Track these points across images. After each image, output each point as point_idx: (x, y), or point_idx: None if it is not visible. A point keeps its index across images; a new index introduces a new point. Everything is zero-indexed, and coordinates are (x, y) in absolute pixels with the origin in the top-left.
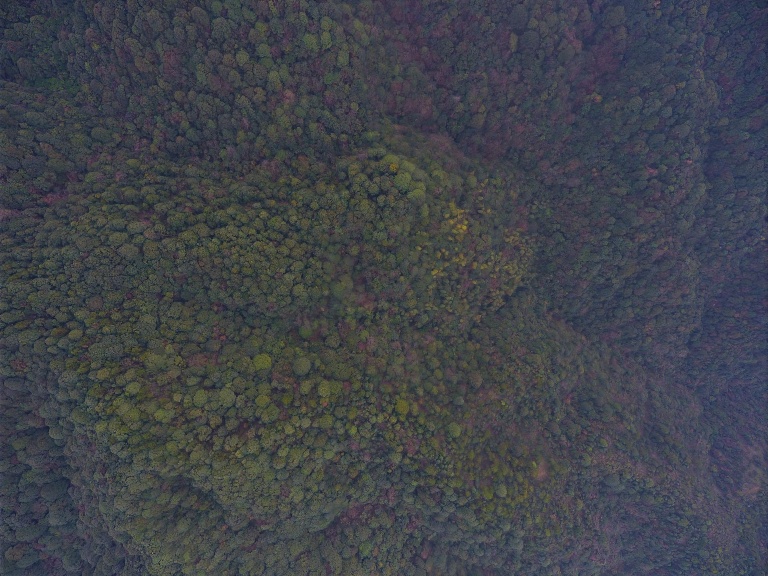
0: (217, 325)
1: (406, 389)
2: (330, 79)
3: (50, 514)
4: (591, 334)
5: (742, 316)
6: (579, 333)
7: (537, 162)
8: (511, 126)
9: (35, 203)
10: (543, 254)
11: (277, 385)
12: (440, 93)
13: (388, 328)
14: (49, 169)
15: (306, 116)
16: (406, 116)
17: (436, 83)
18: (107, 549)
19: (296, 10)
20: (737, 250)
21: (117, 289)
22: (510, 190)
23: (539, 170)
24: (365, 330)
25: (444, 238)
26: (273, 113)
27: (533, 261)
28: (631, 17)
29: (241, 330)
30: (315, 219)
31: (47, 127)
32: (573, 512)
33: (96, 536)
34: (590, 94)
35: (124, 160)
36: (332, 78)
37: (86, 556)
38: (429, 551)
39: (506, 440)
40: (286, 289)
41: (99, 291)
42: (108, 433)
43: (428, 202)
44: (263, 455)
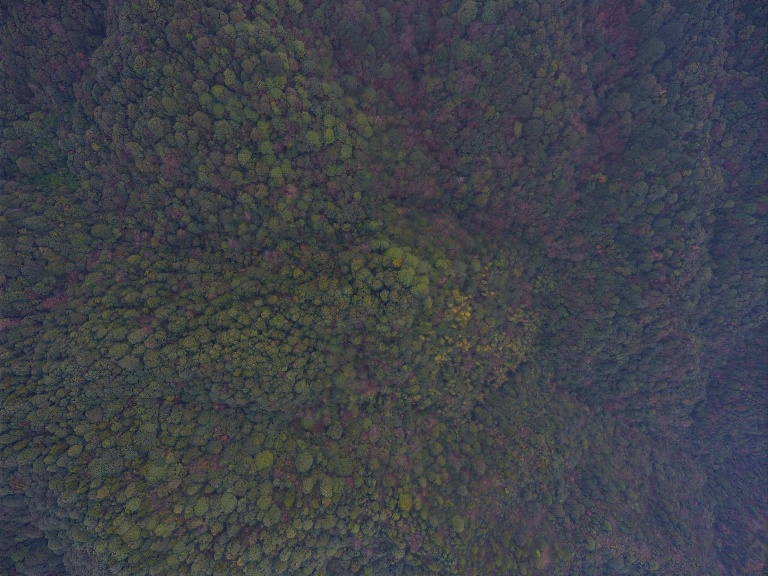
0: (218, 425)
1: (409, 480)
2: (333, 171)
3: None
4: (595, 404)
5: (747, 389)
6: (583, 403)
7: (541, 237)
8: (515, 203)
9: (34, 308)
10: (547, 327)
11: (279, 484)
12: (443, 174)
13: (391, 414)
14: (48, 273)
15: (308, 209)
16: (409, 198)
17: (439, 164)
18: None
19: (299, 109)
20: (742, 325)
21: (117, 398)
22: (514, 268)
23: (543, 245)
24: (368, 418)
25: (447, 326)
26: (275, 207)
27: (536, 334)
28: (637, 103)
29: (242, 427)
30: (317, 315)
31: (46, 230)
32: None
33: None
34: (595, 173)
35: (124, 258)
36: (335, 170)
37: None
38: None
39: (510, 528)
40: (288, 387)
41: (99, 402)
42: (108, 553)
43: (432, 294)
44: (265, 561)
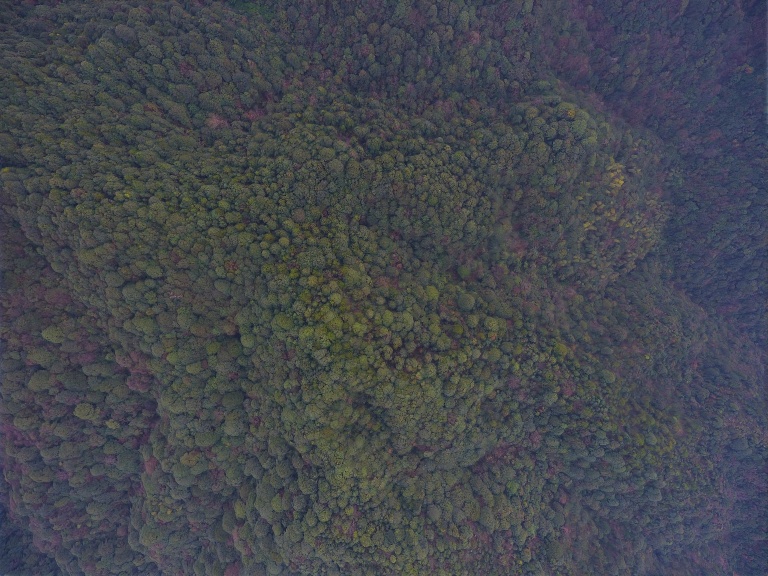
0: (396, 252)
1: (558, 335)
2: (512, 25)
3: (227, 423)
4: (709, 306)
5: None
6: (697, 305)
7: (676, 131)
8: (657, 92)
9: (239, 117)
10: (672, 223)
11: (446, 317)
12: (599, 53)
13: (537, 276)
14: (254, 86)
15: (486, 59)
16: (564, 72)
17: (594, 43)
18: (279, 462)
19: None
20: None
21: (317, 205)
22: (654, 154)
23: (677, 139)
24: (517, 276)
25: (602, 191)
26: (458, 53)
27: (662, 229)
28: None
29: (413, 261)
30: (491, 158)
31: (252, 46)
32: (703, 472)
33: (276, 446)
34: (741, 65)
35: (315, 86)
36: (514, 24)
37: (250, 470)
38: (566, 497)
39: (647, 394)
40: (462, 223)
41: (303, 204)
42: (313, 339)
43: (597, 151)
44: (439, 380)
